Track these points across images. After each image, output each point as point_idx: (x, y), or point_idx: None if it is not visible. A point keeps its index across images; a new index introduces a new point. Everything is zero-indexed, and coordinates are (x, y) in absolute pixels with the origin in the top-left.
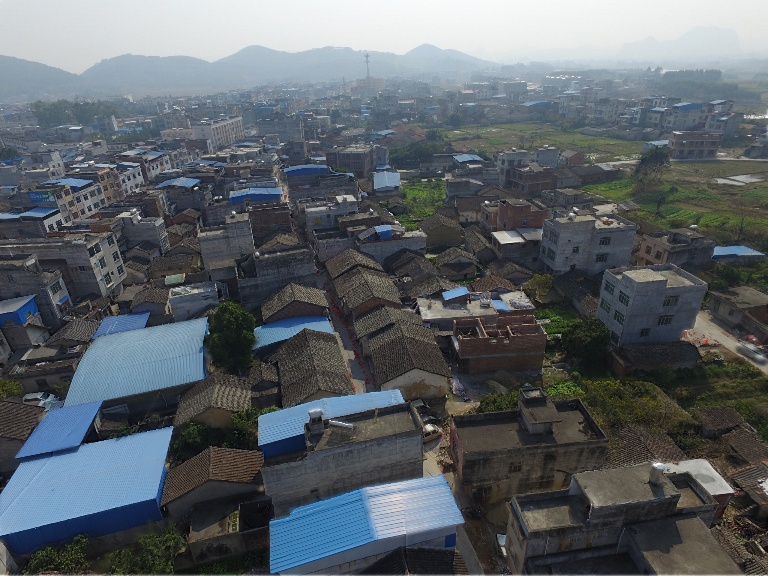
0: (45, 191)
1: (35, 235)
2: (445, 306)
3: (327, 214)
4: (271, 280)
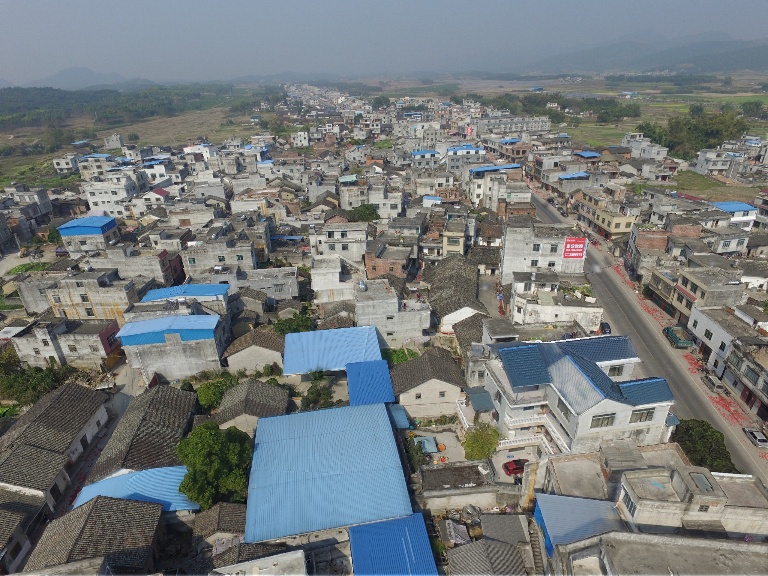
0: None
1: None
2: None
3: None
4: None
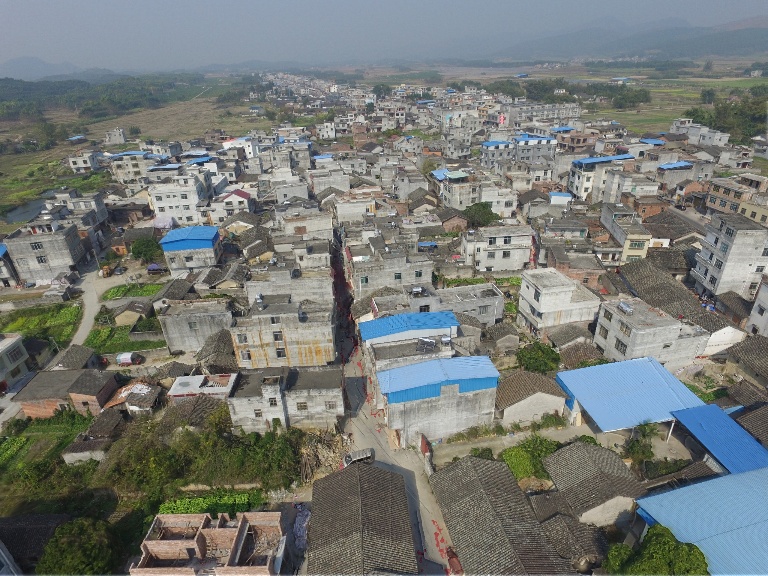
0: None
1: None
2: None
3: None
4: None
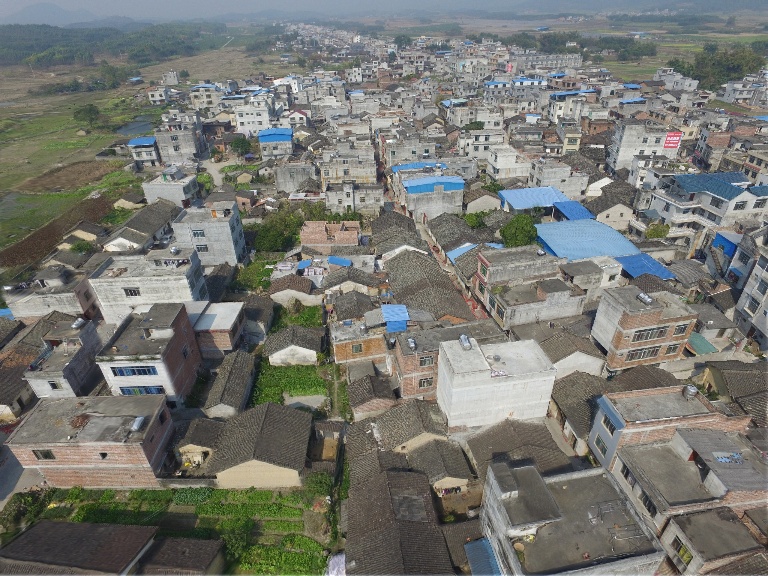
0: None
1: None
2: None
3: None
4: None
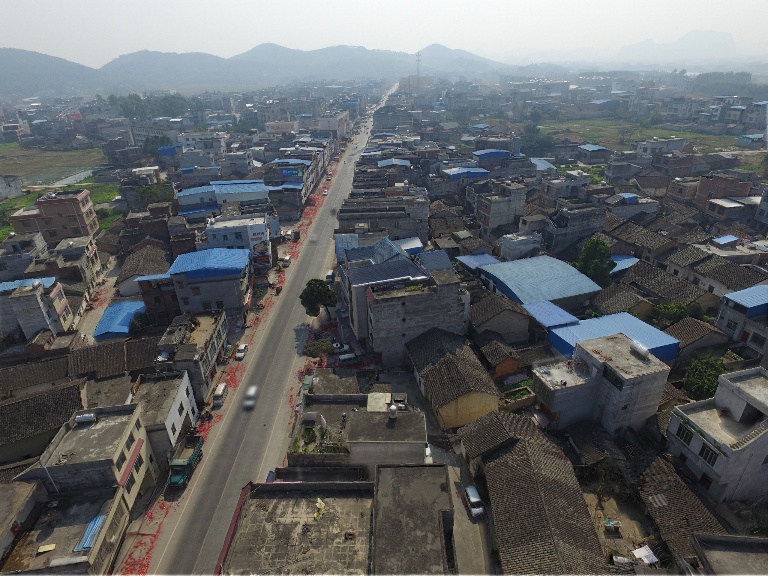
0: (296, 168)
1: (292, 204)
2: (721, 249)
3: (567, 185)
4: (575, 230)
